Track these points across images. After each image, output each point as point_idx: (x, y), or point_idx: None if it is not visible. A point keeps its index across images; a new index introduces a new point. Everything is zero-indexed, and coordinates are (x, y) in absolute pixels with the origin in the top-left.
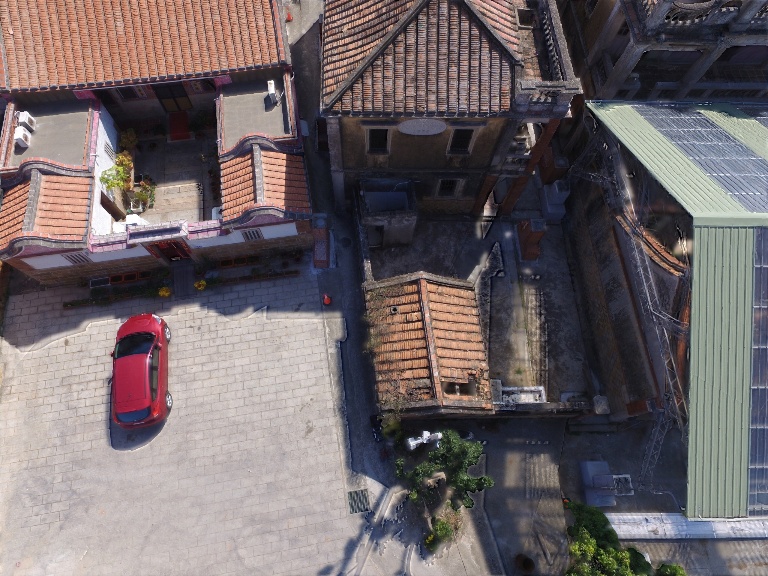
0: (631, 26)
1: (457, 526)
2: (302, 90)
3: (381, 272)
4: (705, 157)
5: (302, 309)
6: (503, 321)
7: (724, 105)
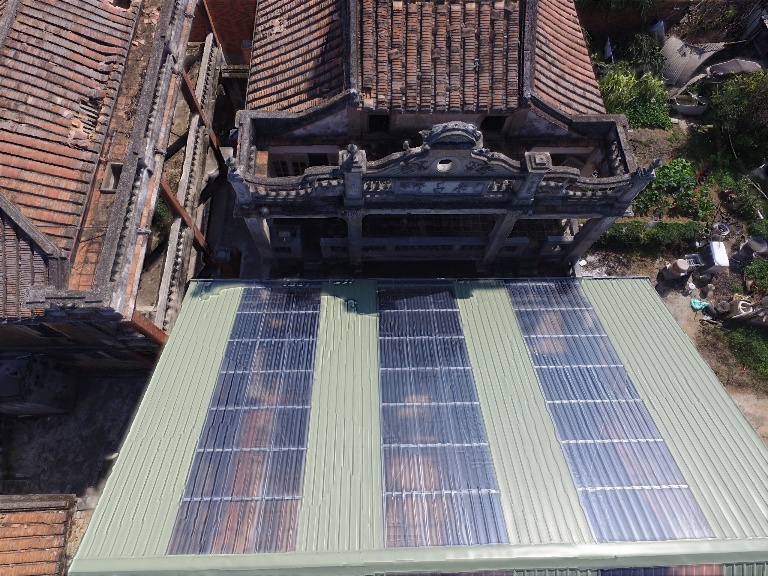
0: None
1: None
2: None
3: (25, 450)
4: (233, 407)
5: None
6: None
7: (366, 284)
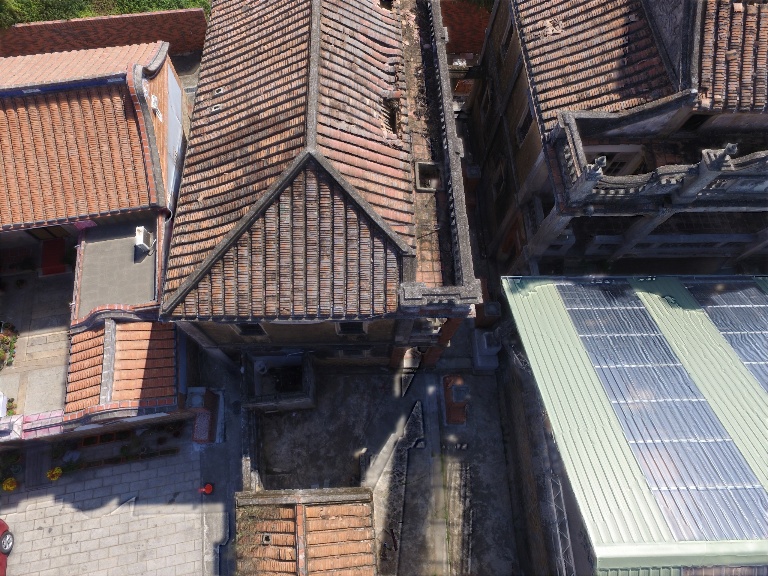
0: (554, 191)
1: None
2: None
3: (278, 446)
4: (633, 400)
5: (178, 500)
6: (419, 509)
7: (670, 281)
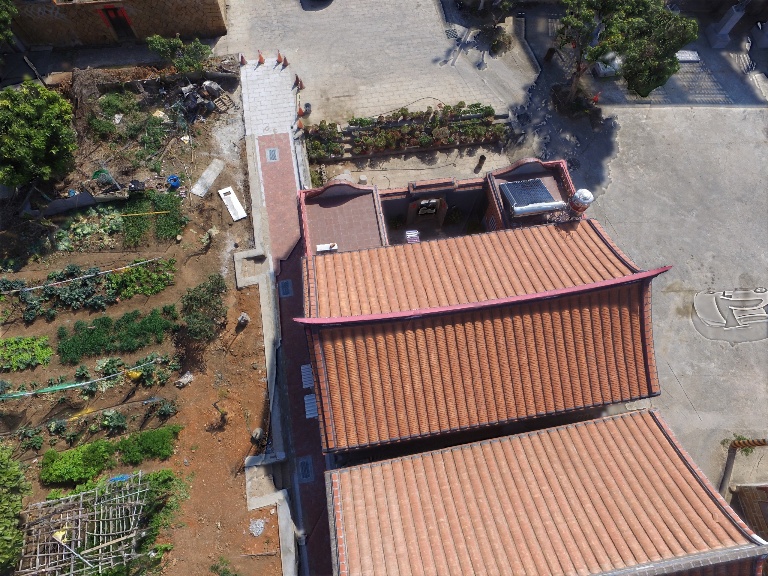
0: None
1: (510, 41)
2: None
3: None
4: None
5: None
6: None
7: None
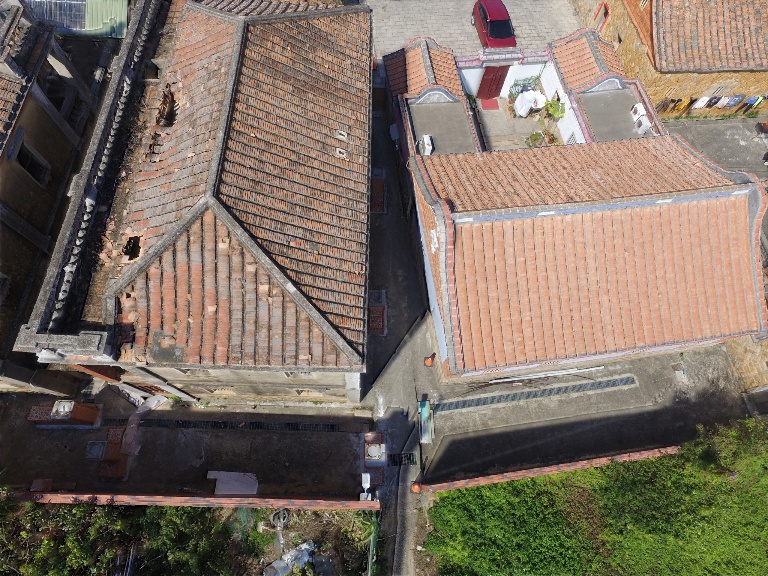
0: (48, 42)
1: None
2: (404, 250)
3: None
4: None
5: None
6: None
7: None
